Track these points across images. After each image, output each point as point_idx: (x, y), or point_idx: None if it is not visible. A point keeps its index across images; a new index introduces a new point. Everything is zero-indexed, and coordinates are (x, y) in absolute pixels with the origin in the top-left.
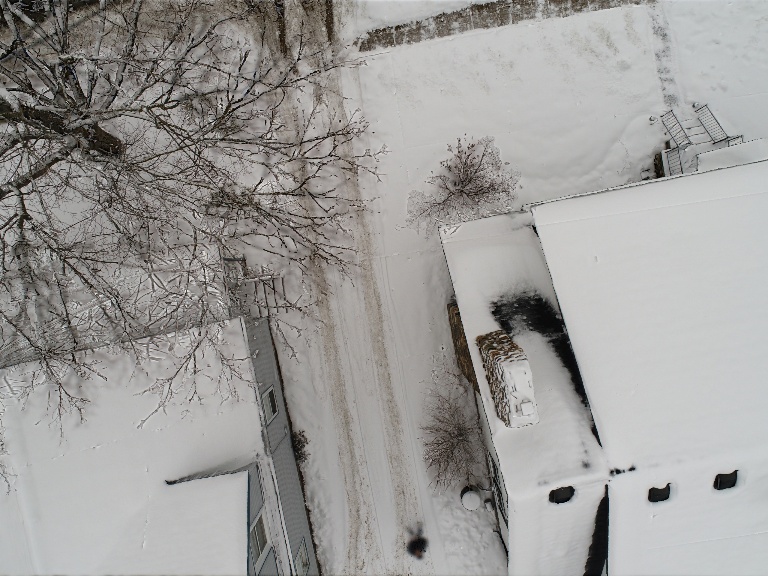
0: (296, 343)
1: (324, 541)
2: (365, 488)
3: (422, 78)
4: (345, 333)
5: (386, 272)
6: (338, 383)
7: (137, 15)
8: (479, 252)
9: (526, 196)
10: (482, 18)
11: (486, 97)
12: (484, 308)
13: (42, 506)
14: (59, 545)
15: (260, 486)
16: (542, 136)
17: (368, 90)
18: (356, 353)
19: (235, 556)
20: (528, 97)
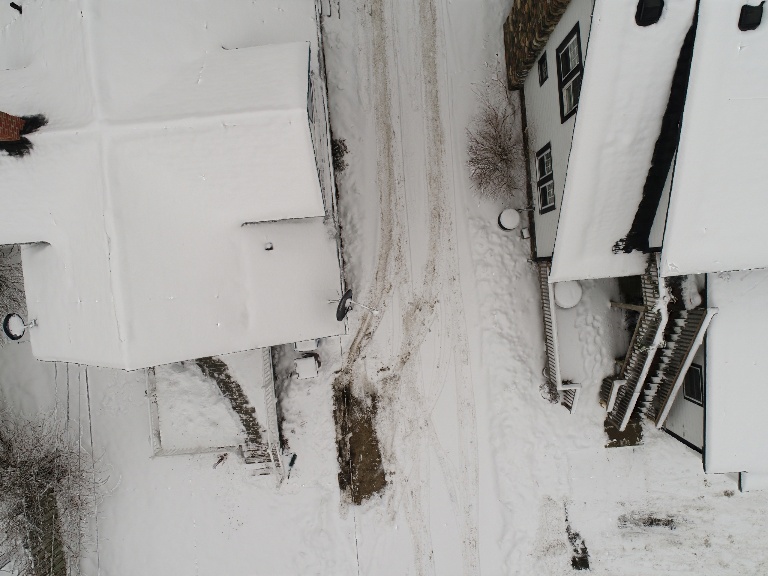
0: (346, 49)
1: (353, 257)
2: (400, 208)
3: None
4: (396, 45)
5: None
6: (384, 97)
7: None
8: None
9: None
10: None
11: None
12: None
13: (102, 6)
14: (115, 53)
15: (311, 104)
16: None
17: None
18: (406, 66)
19: (296, 85)
20: None
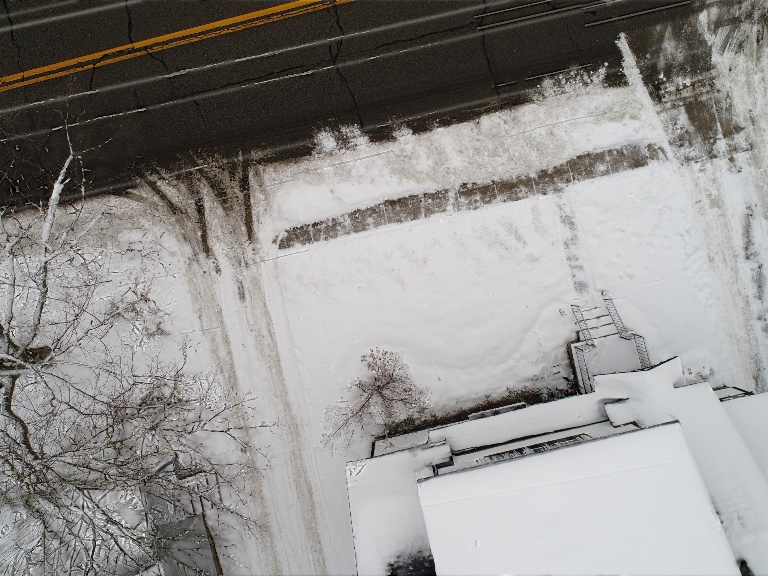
0: (232, 534)
1: None
2: None
3: (339, 276)
4: (279, 521)
5: (315, 462)
6: (275, 569)
7: (44, 280)
8: (379, 503)
9: (445, 388)
10: (395, 213)
11: (402, 292)
12: (381, 572)
13: None
14: None
15: None
16: (458, 328)
17: (288, 290)
18: (291, 541)
19: None
20: (442, 291)
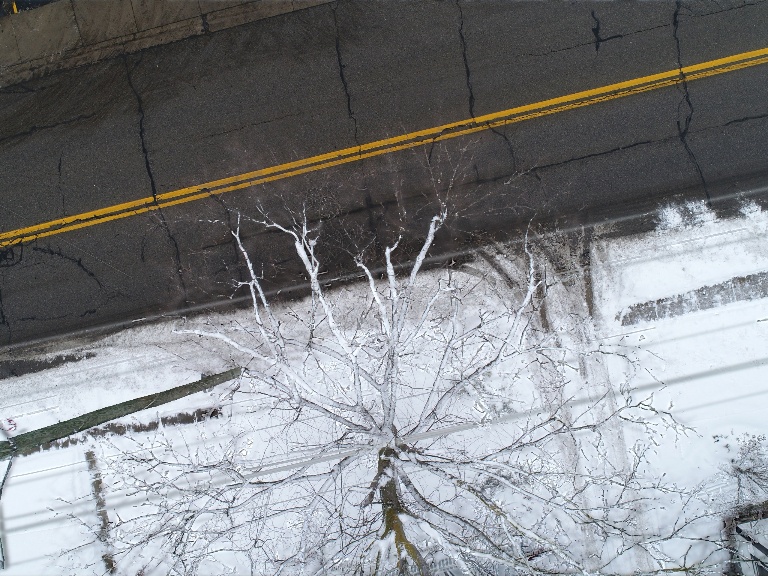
0: None
1: None
2: None
3: (691, 355)
4: None
5: None
6: None
7: None
8: None
9: None
10: (744, 290)
11: (756, 372)
12: None
13: None
14: None
15: None
16: None
17: (638, 368)
18: None
19: None
20: None
